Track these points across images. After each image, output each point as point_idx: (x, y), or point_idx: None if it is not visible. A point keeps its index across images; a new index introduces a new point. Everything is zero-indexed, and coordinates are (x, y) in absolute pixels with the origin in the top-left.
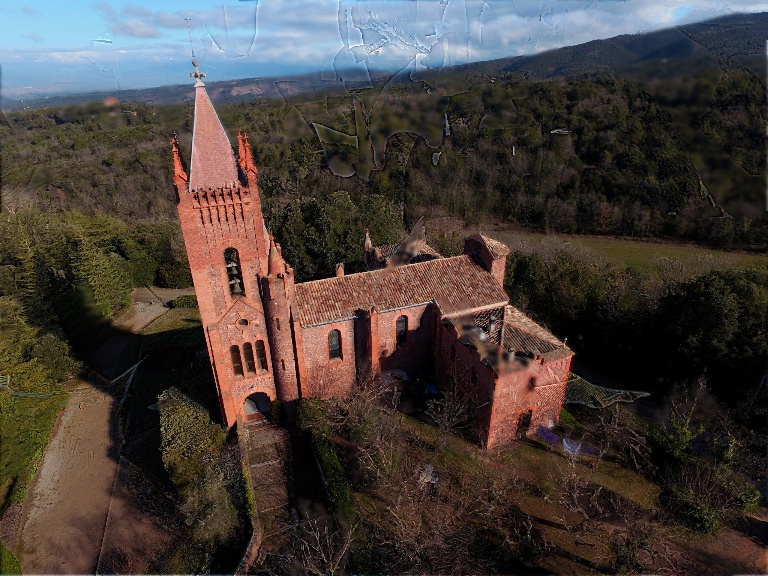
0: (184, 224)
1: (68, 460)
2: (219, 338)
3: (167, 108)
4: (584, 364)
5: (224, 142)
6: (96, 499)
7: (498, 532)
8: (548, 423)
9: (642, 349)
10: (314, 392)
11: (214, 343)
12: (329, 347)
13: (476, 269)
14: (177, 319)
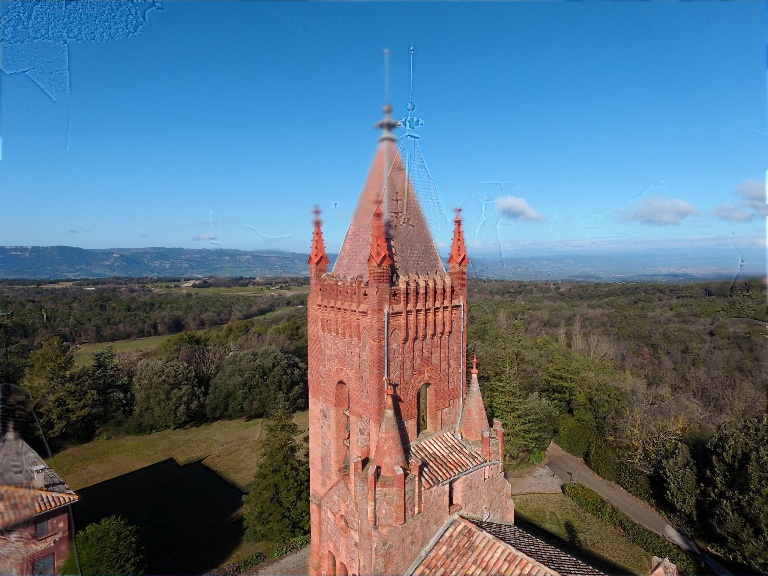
0: (310, 325)
1: (302, 567)
2: (318, 523)
3: (714, 259)
4: None
5: None
6: None
7: None
8: None
9: None
10: None
11: (314, 526)
12: None
13: None
14: (548, 508)
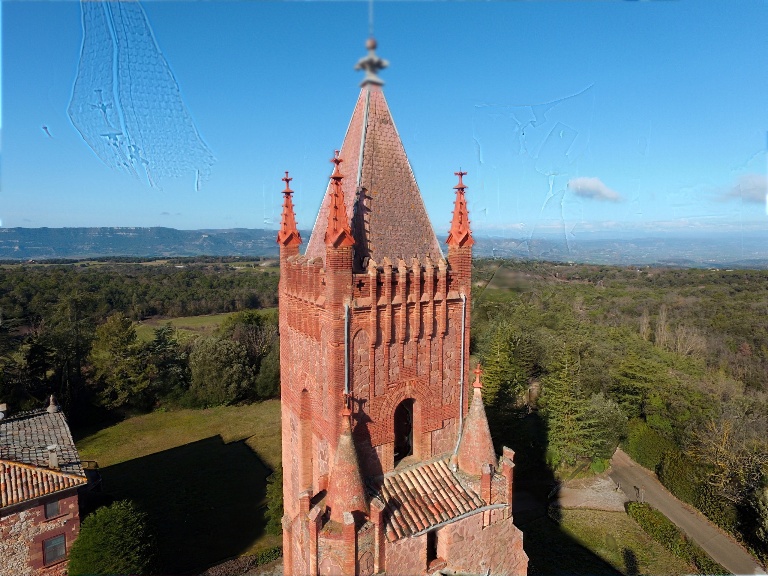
0: (281, 317)
1: None
2: (289, 550)
3: None
4: None
5: (354, 181)
6: None
7: None
8: None
9: None
10: None
11: None
12: None
13: None
14: (605, 529)
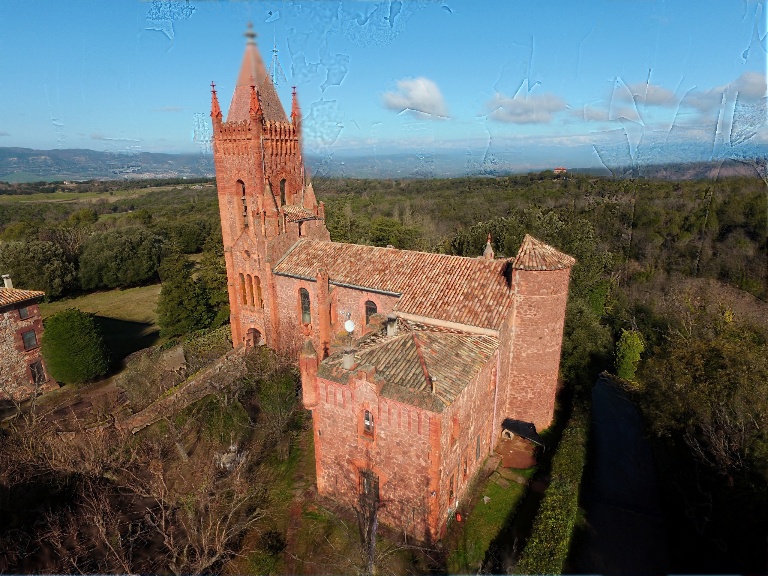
0: None
1: None
2: (231, 261)
3: (482, 140)
4: (670, 546)
5: None
6: (180, 365)
7: (75, 485)
8: (415, 528)
9: (764, 571)
10: (288, 351)
11: (229, 265)
12: (303, 308)
13: (496, 280)
14: None
